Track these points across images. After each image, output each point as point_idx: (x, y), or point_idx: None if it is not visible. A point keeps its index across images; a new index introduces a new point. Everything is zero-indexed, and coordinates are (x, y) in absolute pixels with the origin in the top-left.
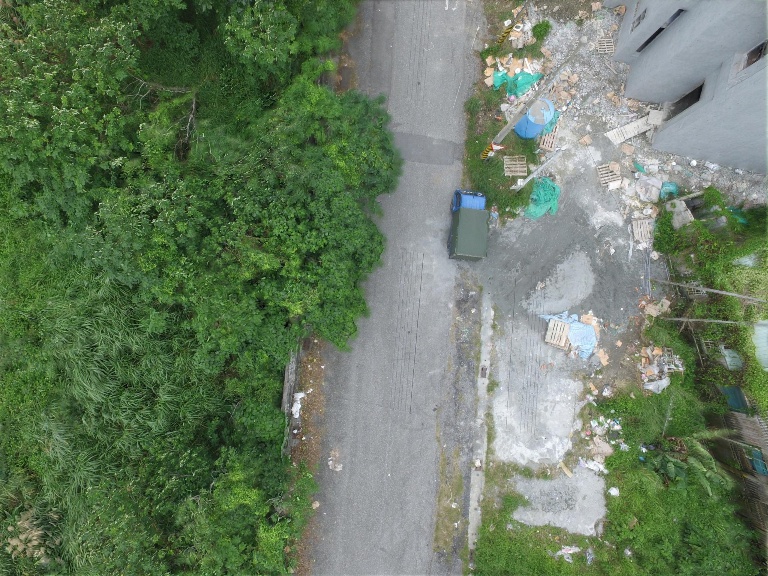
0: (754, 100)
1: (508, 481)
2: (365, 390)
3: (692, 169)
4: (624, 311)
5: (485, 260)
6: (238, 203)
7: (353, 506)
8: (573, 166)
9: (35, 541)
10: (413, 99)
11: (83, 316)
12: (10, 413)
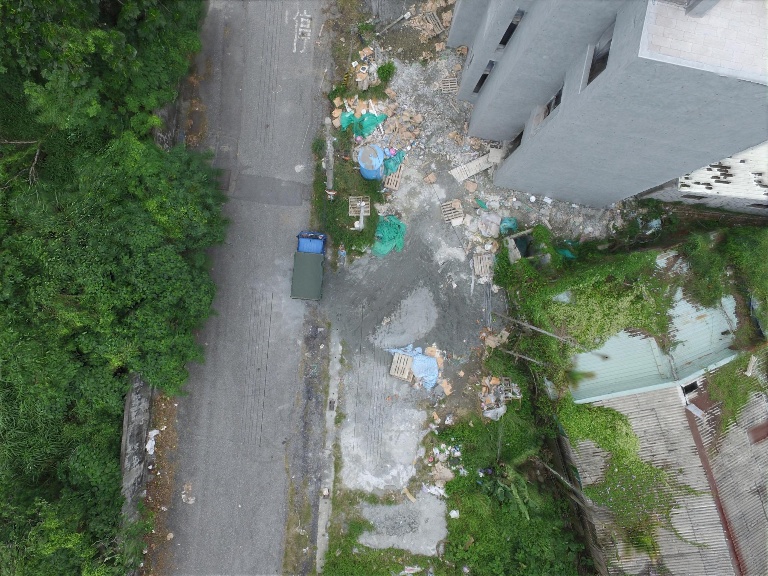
0: (547, 153)
1: (355, 508)
2: (216, 426)
3: (531, 204)
4: (466, 343)
5: (333, 297)
6: (53, 263)
7: (205, 537)
8: (418, 204)
9: None
10: (262, 142)
11: None
12: None
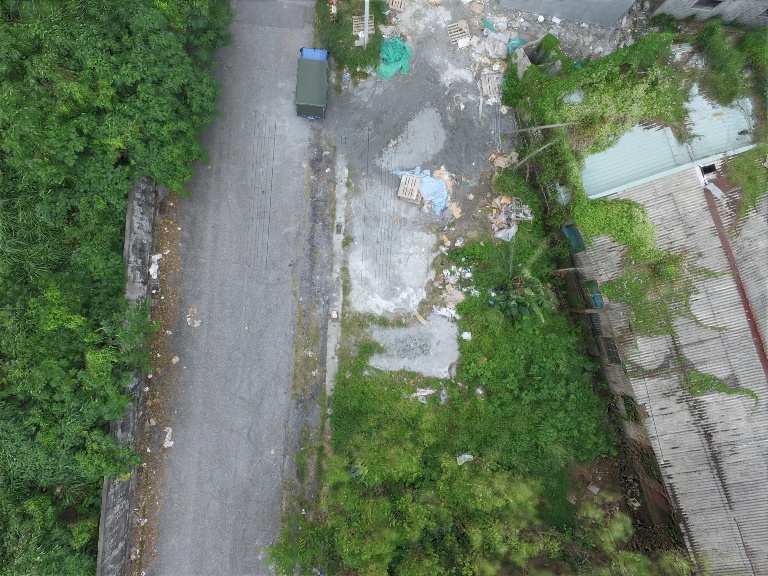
0: None
1: (364, 331)
2: (221, 249)
3: (540, 25)
4: (476, 165)
5: (338, 120)
6: (50, 36)
7: (212, 359)
8: (424, 26)
9: None
10: None
11: None
12: None
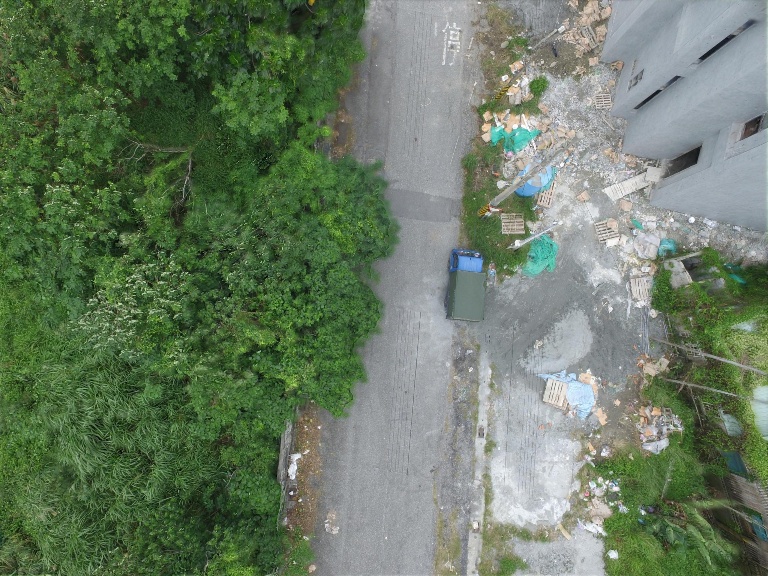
0: (752, 173)
1: (506, 543)
2: (362, 451)
3: (690, 226)
4: (622, 370)
5: None
6: (233, 278)
7: (350, 570)
8: (571, 223)
9: None
10: (410, 155)
11: (78, 380)
12: (4, 477)
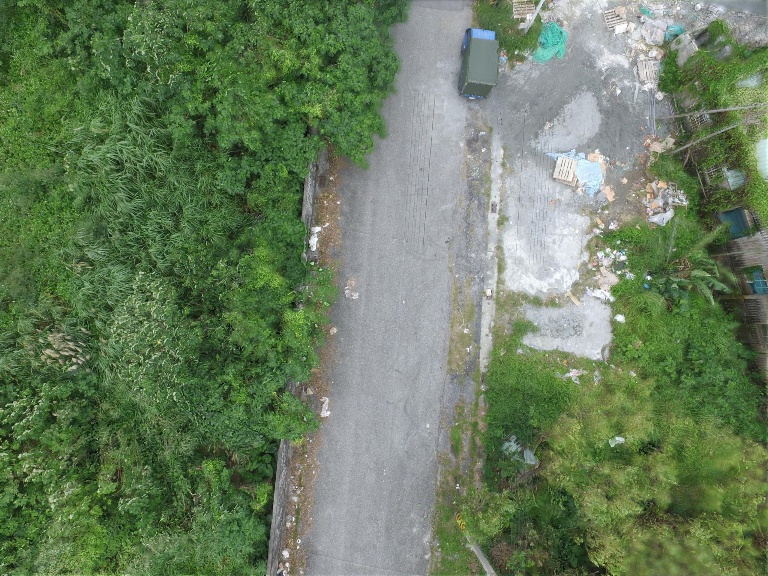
0: None
1: (518, 309)
2: (379, 223)
3: (696, 13)
4: (630, 150)
5: (495, 102)
6: (259, 5)
7: (369, 331)
8: (580, 12)
9: (67, 352)
10: None
11: (108, 145)
12: (39, 242)
